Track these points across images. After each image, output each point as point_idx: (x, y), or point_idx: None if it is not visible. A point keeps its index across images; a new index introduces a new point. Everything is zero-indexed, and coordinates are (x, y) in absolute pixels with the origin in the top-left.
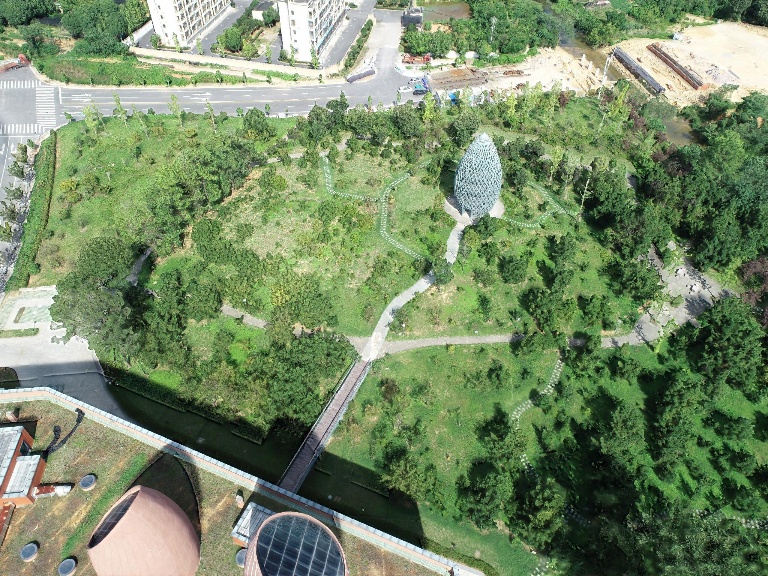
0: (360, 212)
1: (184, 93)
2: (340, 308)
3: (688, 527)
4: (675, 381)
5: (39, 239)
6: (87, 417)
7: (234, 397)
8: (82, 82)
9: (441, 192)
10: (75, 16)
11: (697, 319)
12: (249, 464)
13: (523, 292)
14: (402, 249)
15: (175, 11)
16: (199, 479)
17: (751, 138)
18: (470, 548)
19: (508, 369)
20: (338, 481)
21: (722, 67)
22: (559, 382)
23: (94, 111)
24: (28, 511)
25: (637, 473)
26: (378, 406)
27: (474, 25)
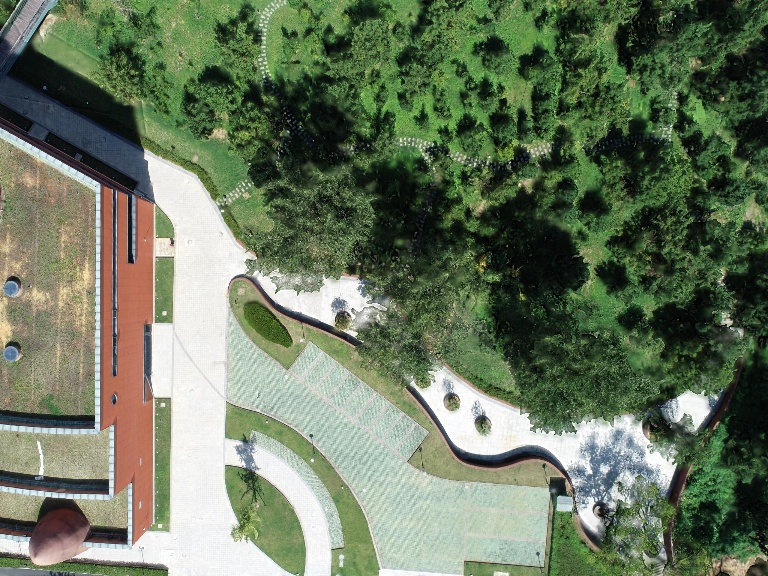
0: None
1: None
2: None
3: (316, 180)
4: None
5: None
6: None
7: None
8: None
9: None
10: None
11: None
12: None
13: None
14: None
15: None
16: None
17: None
18: (189, 152)
19: None
20: (62, 69)
21: None
22: None
23: None
24: None
25: (377, 97)
26: None
27: None
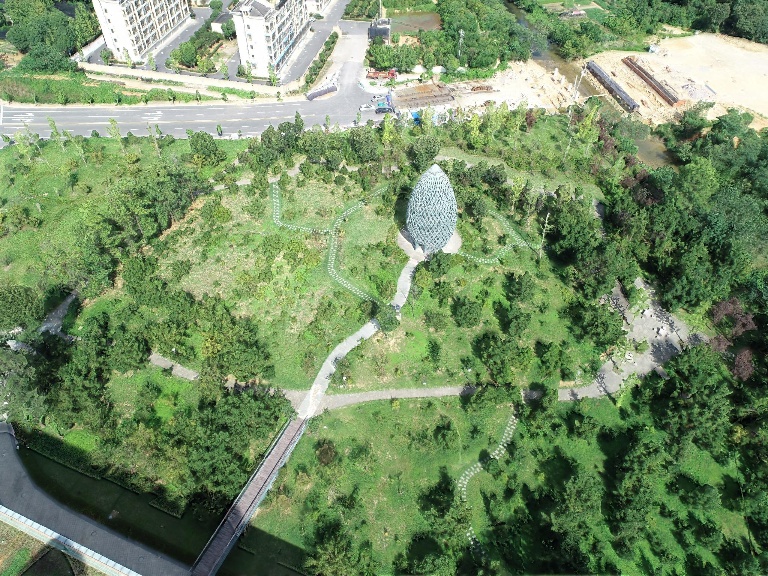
0: (307, 246)
1: (134, 112)
2: (278, 357)
3: None
4: (637, 440)
5: None
6: None
7: (151, 466)
8: (26, 100)
9: (395, 224)
10: (21, 30)
11: (663, 367)
12: (165, 542)
13: (477, 337)
14: (350, 288)
15: (126, 25)
16: None
17: (726, 160)
18: None
19: (455, 429)
20: (263, 562)
21: (699, 82)
22: (512, 442)
23: (36, 132)
24: None
25: (593, 549)
26: (312, 471)
27: (443, 37)
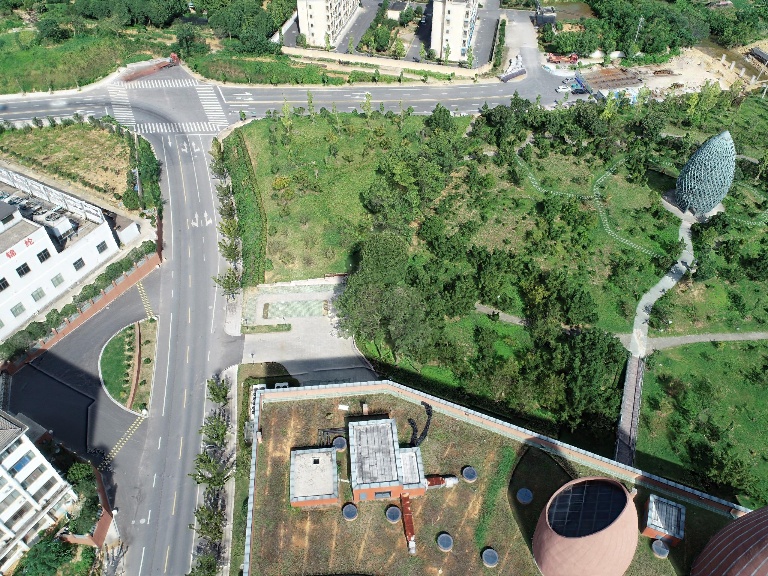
0: None
1: (343, 92)
2: None
3: None
4: None
5: (265, 236)
6: (436, 410)
7: (530, 392)
8: (239, 81)
9: (654, 190)
10: (223, 15)
11: None
12: None
13: None
14: (634, 247)
15: (326, 11)
16: (576, 472)
17: None
18: None
19: None
20: None
21: None
22: None
23: (261, 110)
24: (422, 502)
25: None
26: None
27: (607, 25)
